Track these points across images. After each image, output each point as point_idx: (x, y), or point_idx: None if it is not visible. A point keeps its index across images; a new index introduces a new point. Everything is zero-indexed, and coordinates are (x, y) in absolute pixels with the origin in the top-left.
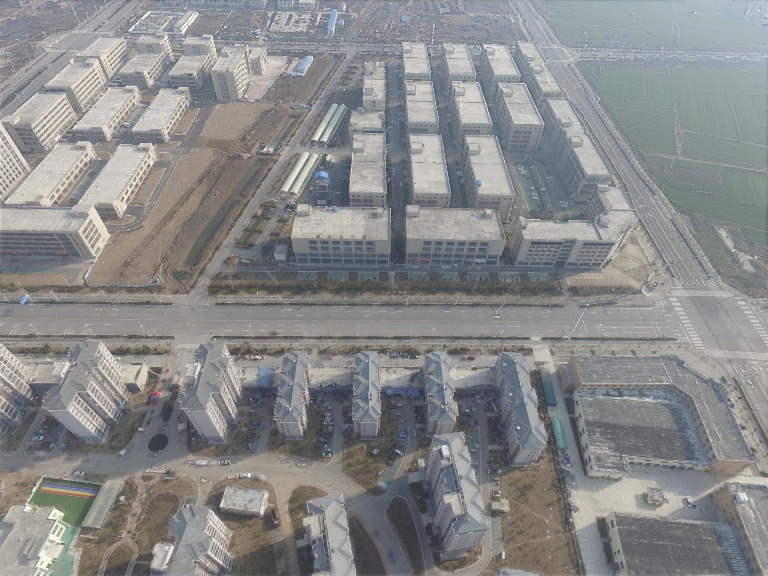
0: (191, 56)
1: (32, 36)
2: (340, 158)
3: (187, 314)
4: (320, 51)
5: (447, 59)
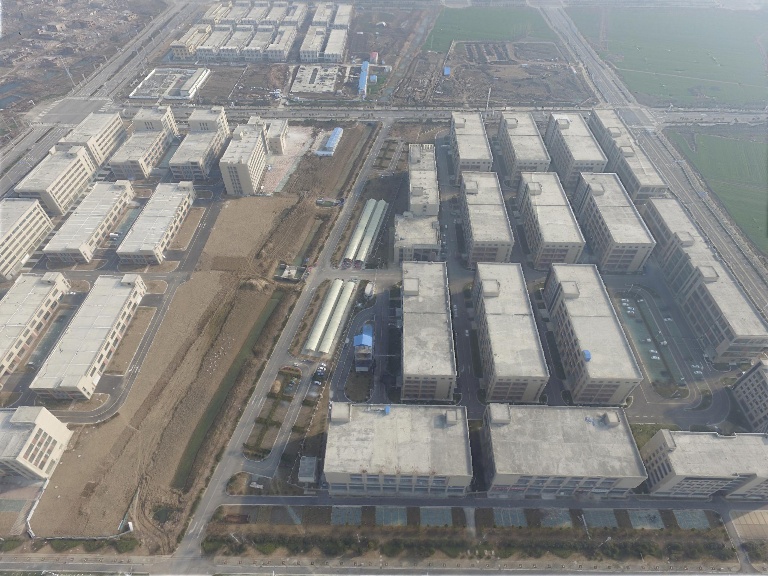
0: (198, 134)
1: (19, 105)
2: (383, 287)
3: None
4: (351, 119)
5: (510, 137)
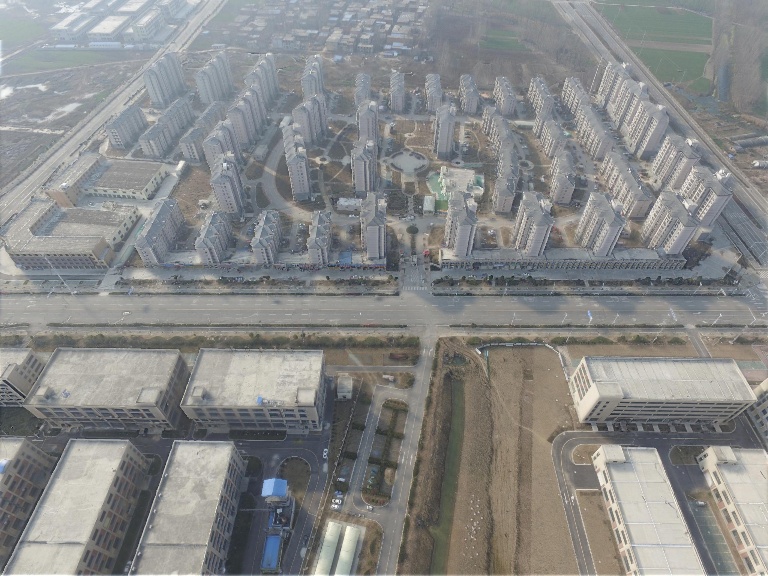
0: None
1: None
2: None
3: (431, 316)
4: None
5: None
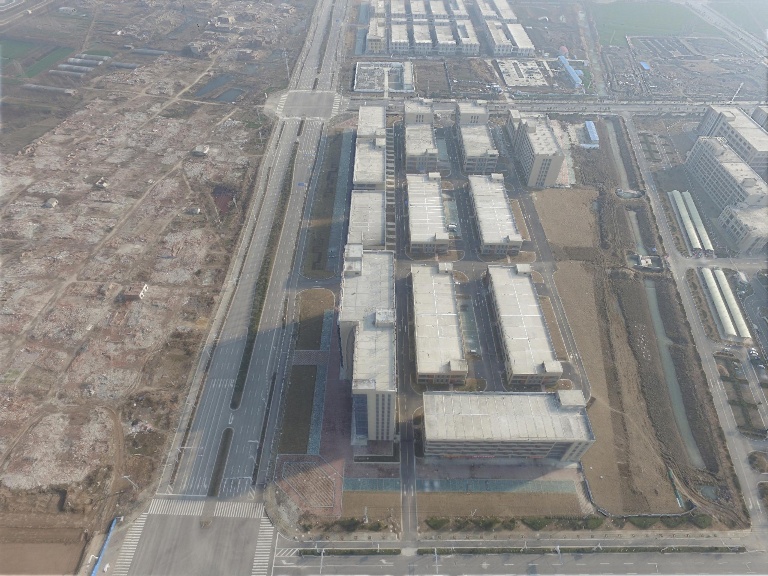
0: (470, 127)
1: (248, 98)
2: (748, 275)
3: None
4: (588, 112)
5: None
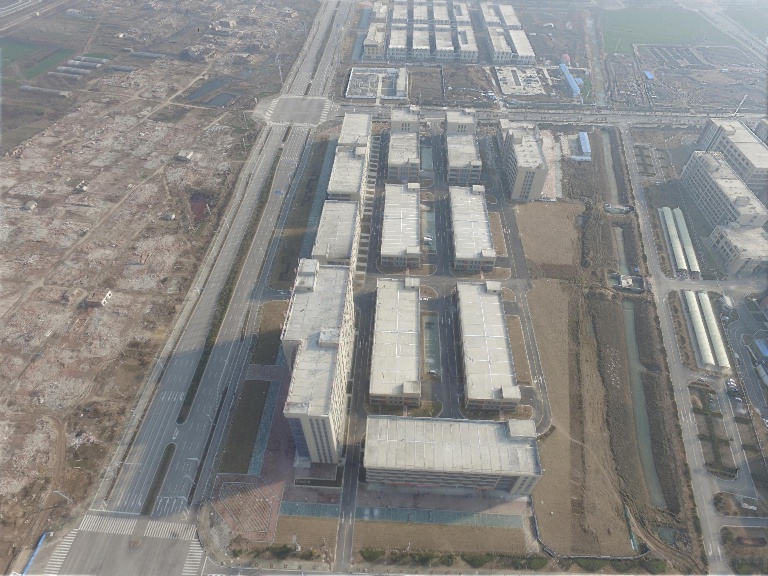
0: (456, 137)
1: (239, 102)
2: (735, 299)
3: None
4: (583, 123)
5: None
